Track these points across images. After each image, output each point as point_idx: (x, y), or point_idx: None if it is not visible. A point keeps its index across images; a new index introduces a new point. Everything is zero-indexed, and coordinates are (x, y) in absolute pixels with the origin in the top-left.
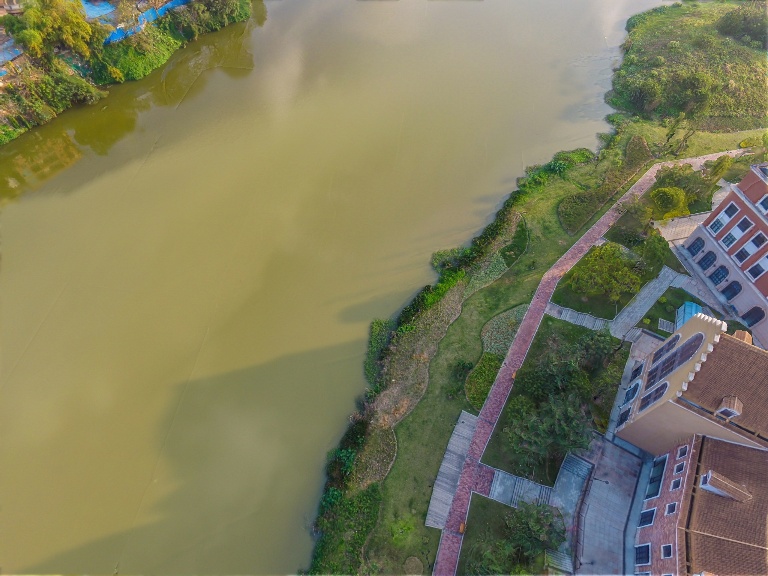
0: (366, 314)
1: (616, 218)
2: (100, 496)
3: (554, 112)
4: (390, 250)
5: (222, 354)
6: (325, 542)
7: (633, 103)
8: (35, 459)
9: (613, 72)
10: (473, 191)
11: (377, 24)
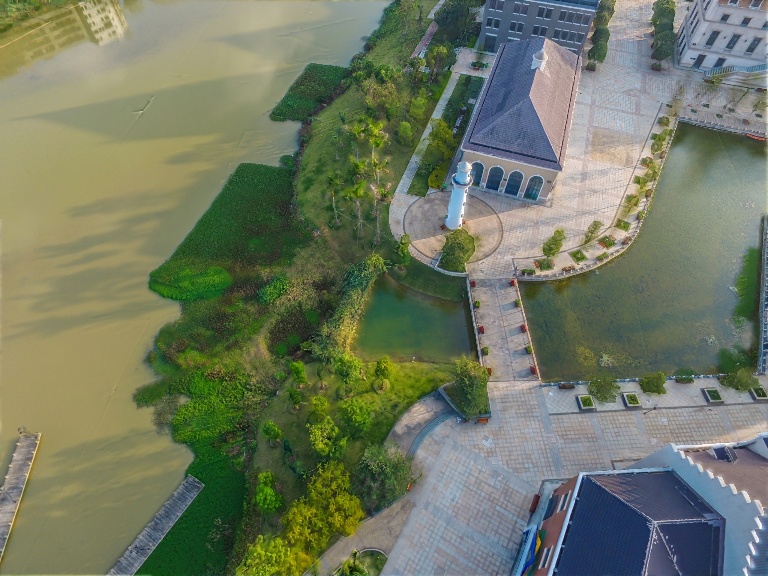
0: None
1: None
2: (288, 14)
3: None
4: None
5: None
6: None
7: None
8: (257, 7)
9: None
10: None
11: None
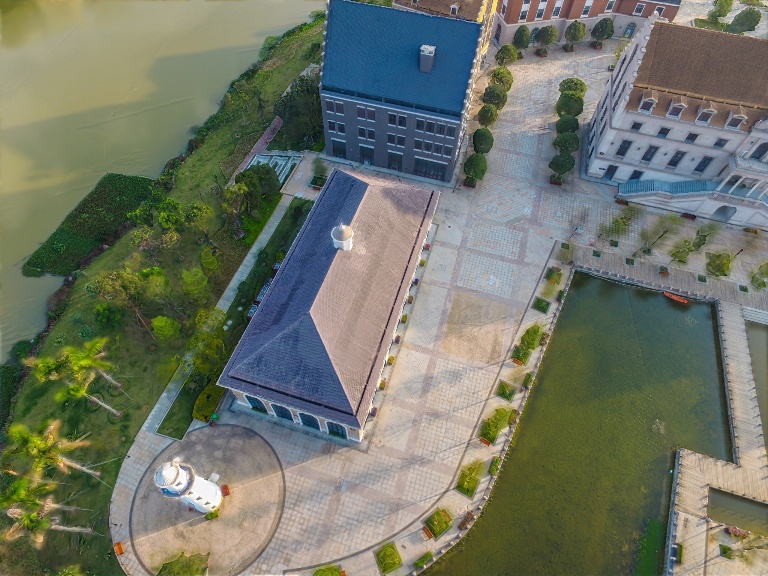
0: (264, 34)
1: None
2: (104, 93)
3: None
4: (285, 10)
5: (175, 48)
6: (225, 104)
7: None
8: (67, 81)
9: None
10: None
11: None
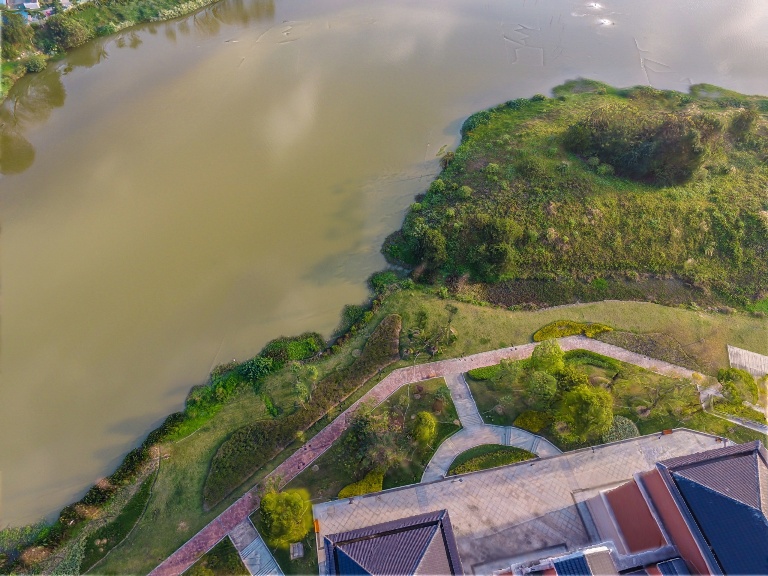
0: None
1: (288, 478)
2: None
3: (303, 267)
4: None
5: None
6: None
7: (415, 255)
8: None
9: (414, 200)
10: (118, 410)
11: (146, 122)
